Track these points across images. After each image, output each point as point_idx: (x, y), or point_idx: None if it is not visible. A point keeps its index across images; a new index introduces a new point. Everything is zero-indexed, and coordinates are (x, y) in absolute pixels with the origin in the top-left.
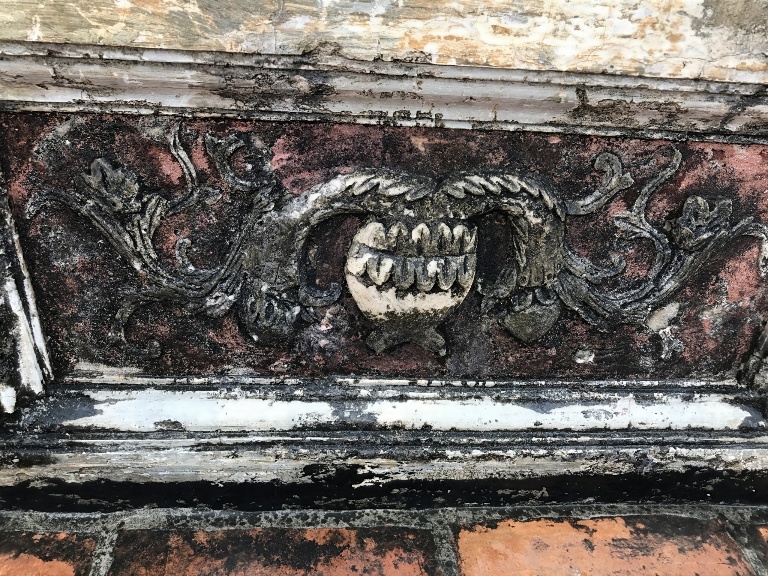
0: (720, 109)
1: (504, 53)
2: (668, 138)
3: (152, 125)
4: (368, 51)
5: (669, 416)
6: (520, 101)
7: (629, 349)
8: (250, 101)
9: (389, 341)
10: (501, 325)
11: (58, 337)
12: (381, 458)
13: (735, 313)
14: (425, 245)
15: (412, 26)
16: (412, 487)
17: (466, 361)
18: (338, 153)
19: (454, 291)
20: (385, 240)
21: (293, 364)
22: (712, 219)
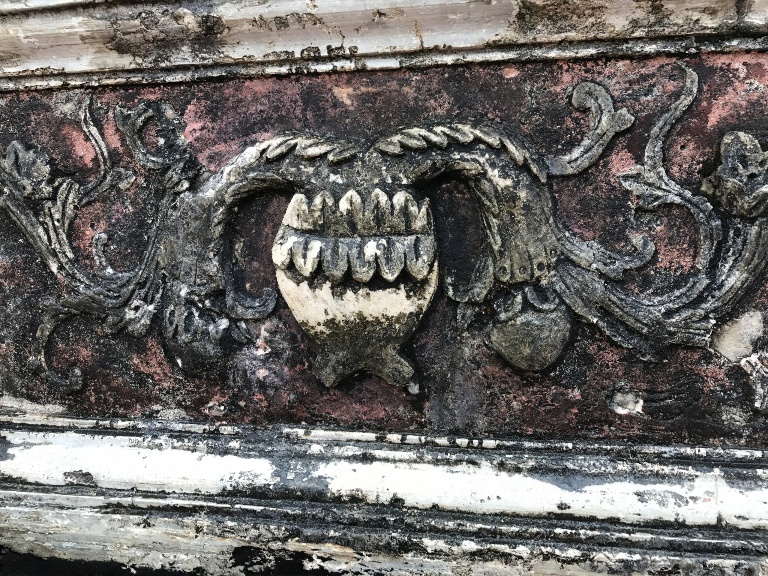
0: None
1: None
2: (668, 50)
3: (65, 101)
4: None
5: None
6: (440, 9)
7: (698, 392)
8: (148, 56)
9: (338, 368)
10: (489, 348)
11: None
12: (332, 543)
13: None
14: (357, 218)
15: None
16: None
17: (451, 407)
18: (254, 117)
19: (409, 289)
20: (309, 215)
21: (230, 406)
22: None
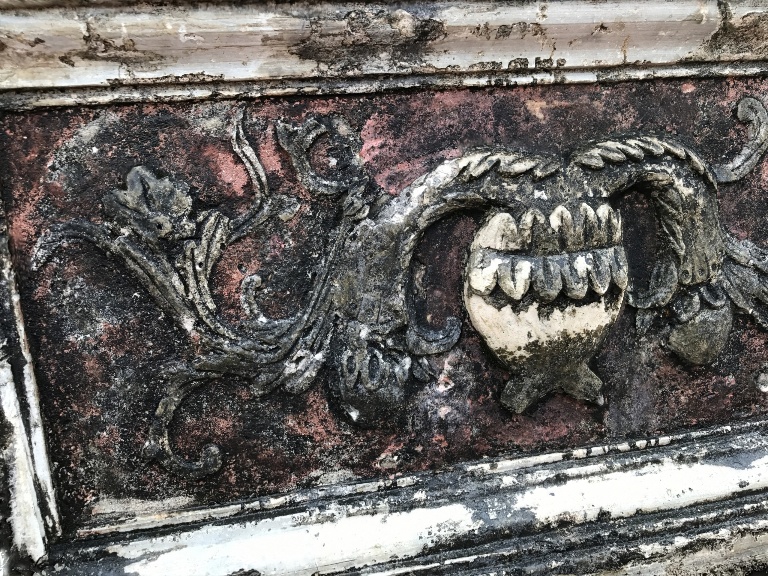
0: None
1: None
2: None
3: (208, 115)
4: None
5: None
6: (656, 26)
7: None
8: (336, 62)
9: (532, 391)
10: (665, 349)
11: (69, 462)
12: (555, 575)
13: None
14: (568, 234)
15: None
16: None
17: (628, 412)
18: (441, 132)
19: (607, 301)
20: (517, 235)
21: (405, 454)
22: None
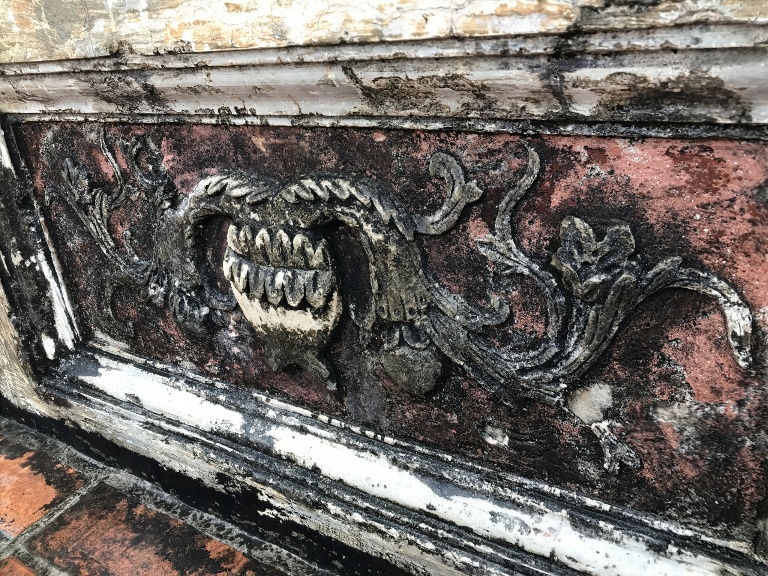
0: (527, 80)
1: (243, 32)
2: (507, 130)
3: (90, 130)
4: (147, 45)
5: (618, 564)
6: (300, 88)
7: (555, 441)
8: (125, 105)
9: (278, 360)
10: None
11: (82, 306)
12: (272, 488)
13: (716, 424)
14: (268, 252)
15: (168, 16)
16: (308, 536)
17: (363, 405)
18: (204, 154)
19: (315, 312)
20: (238, 244)
21: (221, 368)
22: (603, 254)
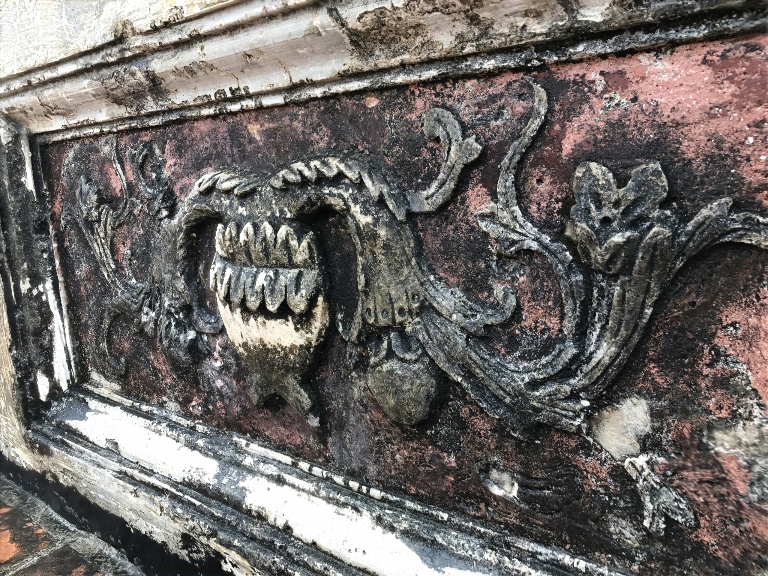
0: None
1: None
2: (508, 65)
3: (105, 144)
4: (146, 20)
5: None
6: (287, 45)
7: (577, 489)
8: (133, 106)
9: (259, 389)
10: None
11: (82, 343)
12: (236, 552)
13: None
14: (251, 249)
15: None
16: None
17: (349, 447)
18: (203, 153)
19: (297, 321)
20: (224, 244)
21: (205, 407)
22: (627, 204)
